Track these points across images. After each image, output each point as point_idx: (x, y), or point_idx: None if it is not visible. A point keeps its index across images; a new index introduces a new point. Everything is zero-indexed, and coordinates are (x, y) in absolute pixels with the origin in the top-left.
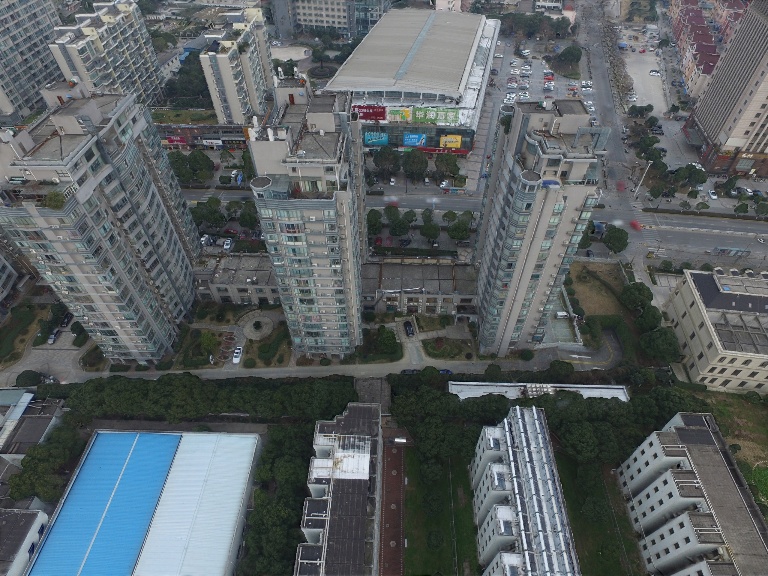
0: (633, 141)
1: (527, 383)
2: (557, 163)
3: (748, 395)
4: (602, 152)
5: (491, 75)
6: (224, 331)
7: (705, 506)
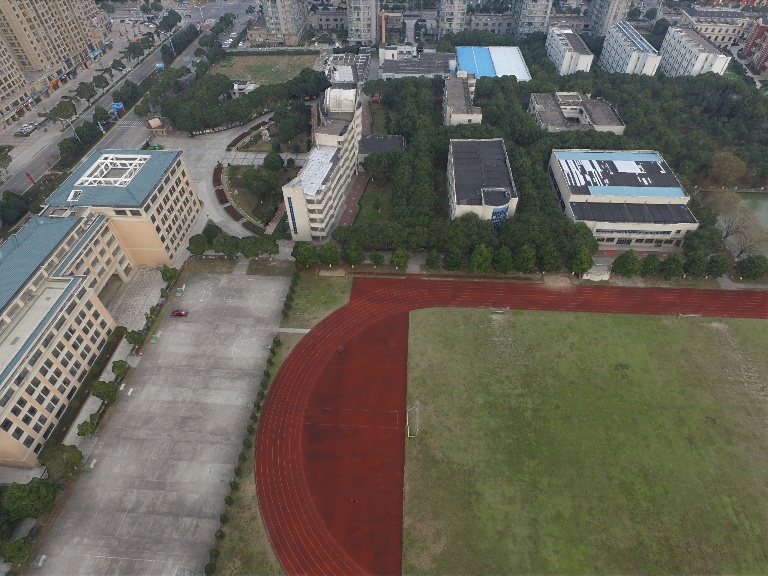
0: None
1: None
2: None
3: None
4: None
5: None
6: None
7: None
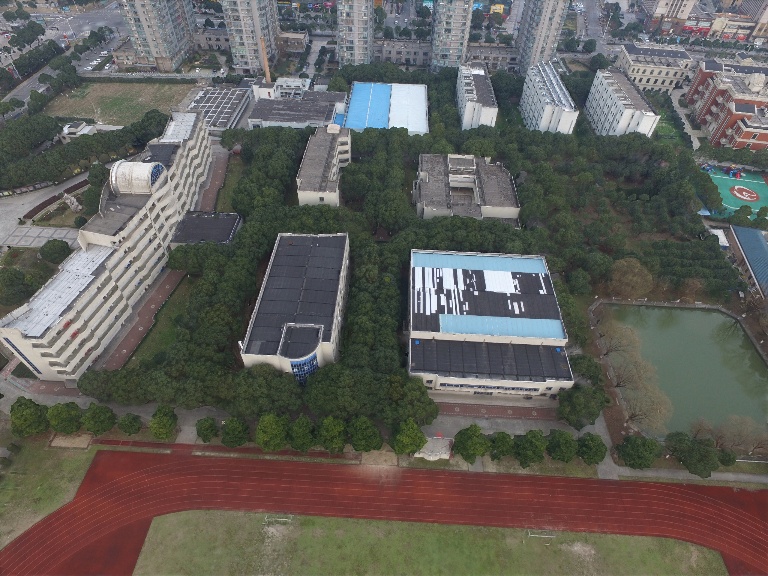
0: None
1: None
2: None
3: (646, 91)
4: None
5: None
6: None
7: None
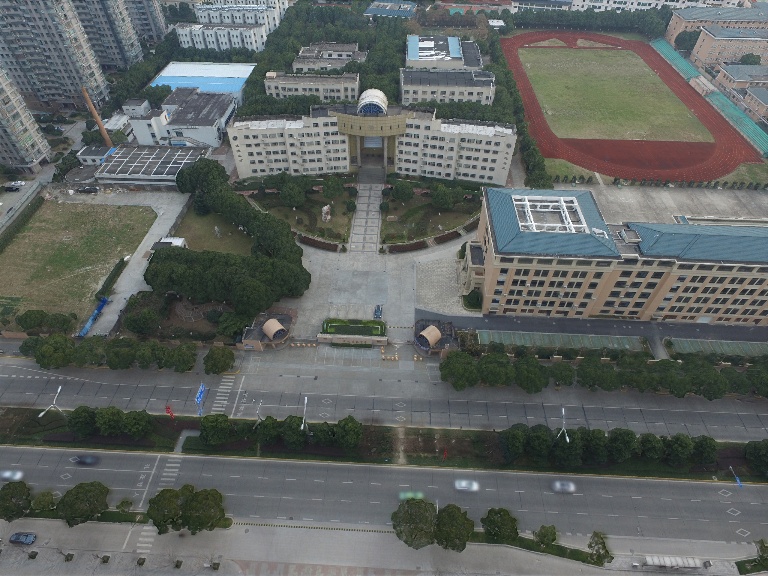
0: None
1: None
2: None
3: None
4: None
5: None
6: None
7: None
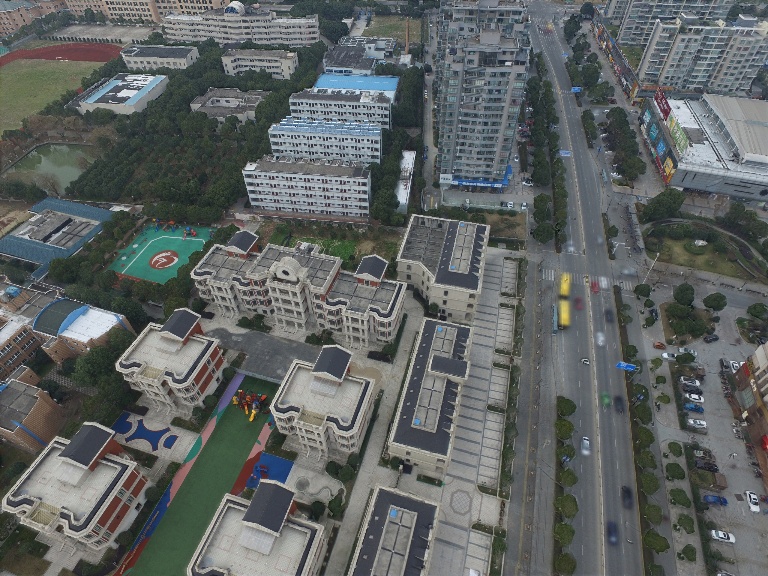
0: None
1: None
2: None
3: None
4: None
5: None
6: None
7: None
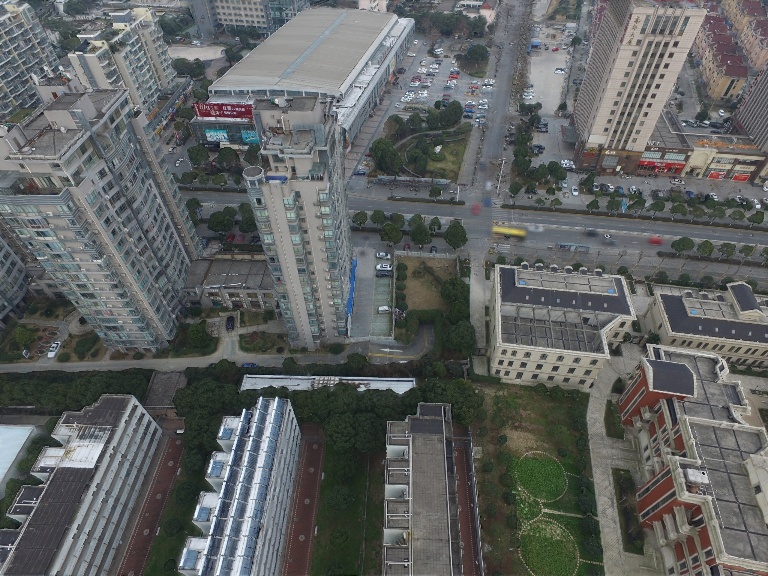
0: (515, 139)
1: (316, 376)
2: (281, 159)
3: (535, 387)
4: (323, 148)
5: (397, 74)
6: (50, 326)
7: (406, 493)
